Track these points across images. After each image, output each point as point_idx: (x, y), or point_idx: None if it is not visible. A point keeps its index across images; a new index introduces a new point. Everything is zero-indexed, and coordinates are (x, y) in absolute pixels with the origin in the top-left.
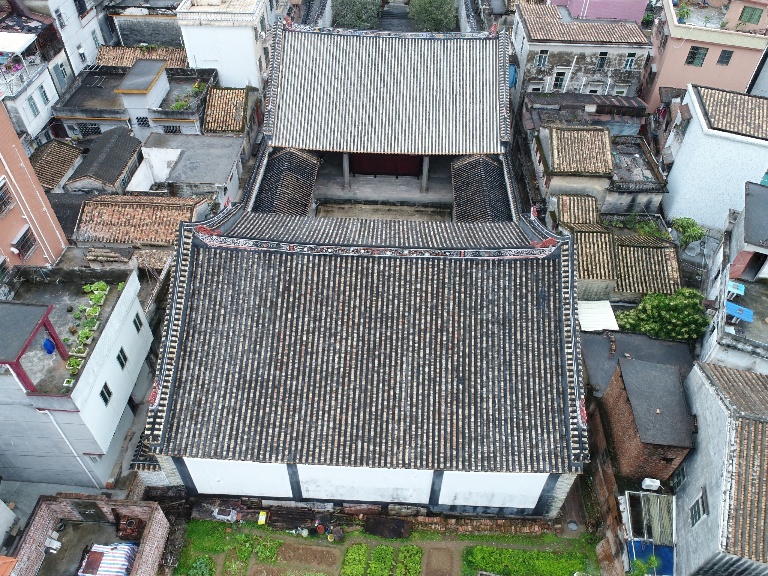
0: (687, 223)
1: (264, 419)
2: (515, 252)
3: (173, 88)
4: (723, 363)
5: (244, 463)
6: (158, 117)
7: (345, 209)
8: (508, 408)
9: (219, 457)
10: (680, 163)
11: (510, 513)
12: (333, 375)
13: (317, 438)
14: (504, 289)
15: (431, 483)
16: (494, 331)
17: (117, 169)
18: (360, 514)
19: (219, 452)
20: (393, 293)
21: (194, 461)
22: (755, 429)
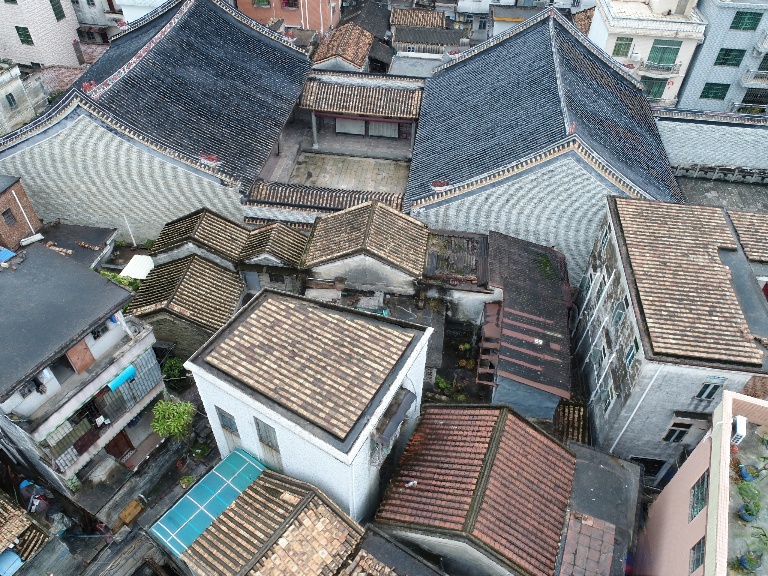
0: None
1: None
2: None
3: None
4: None
5: None
6: None
7: None
8: None
9: None
10: None
11: None
12: None
13: None
14: None
15: None
16: None
17: (414, 39)
18: None
19: None
20: None
21: None
22: None
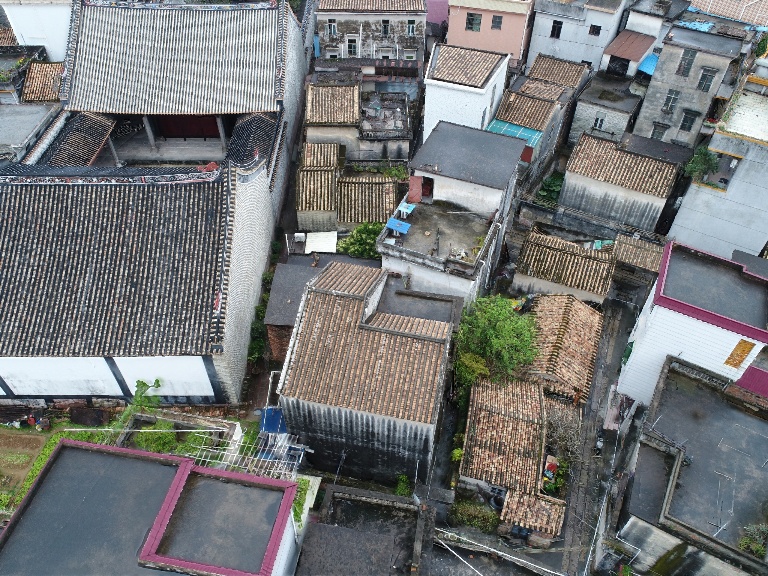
0: None
1: None
2: (187, 176)
3: (0, 64)
4: (390, 271)
5: None
6: None
7: None
8: (170, 305)
9: None
10: None
11: (198, 402)
12: (24, 284)
13: (3, 335)
14: (179, 208)
15: (112, 373)
16: (167, 243)
17: None
18: (68, 408)
19: None
20: (83, 215)
21: None
22: (322, 300)
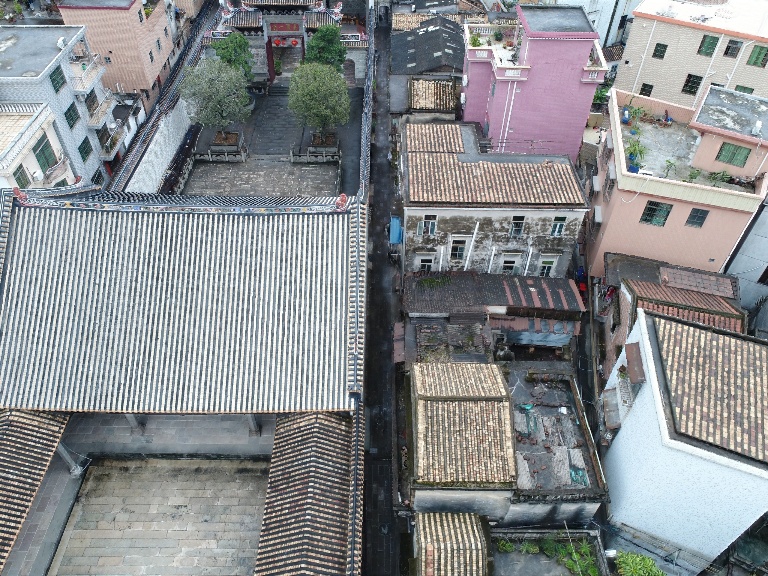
0: None
1: None
2: None
3: None
4: None
5: None
6: None
7: (129, 472)
8: None
9: None
10: (629, 444)
11: None
12: None
13: None
14: None
15: None
16: None
17: None
18: None
19: None
20: None
21: None
22: None
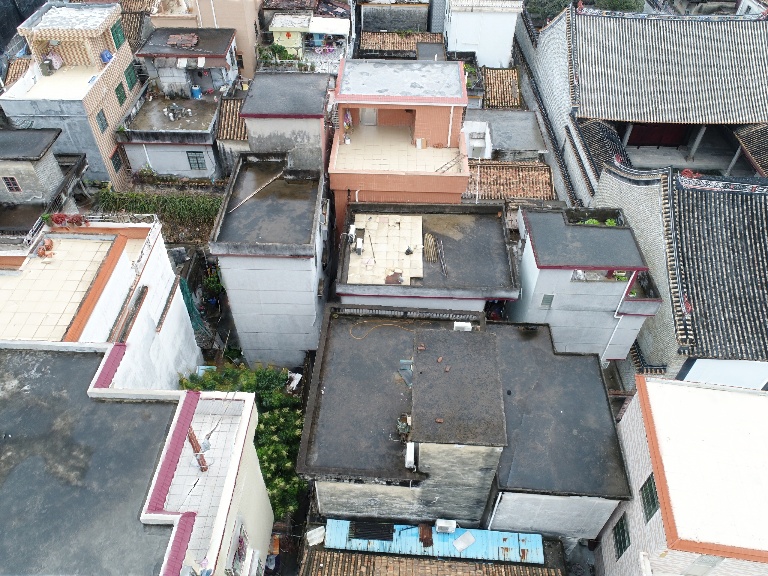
0: None
1: (762, 328)
2: None
3: None
4: None
5: (744, 365)
6: None
7: None
8: None
9: (737, 357)
10: None
11: None
12: None
13: None
14: None
15: None
16: None
17: None
18: None
19: (735, 354)
20: None
21: (702, 364)
22: None
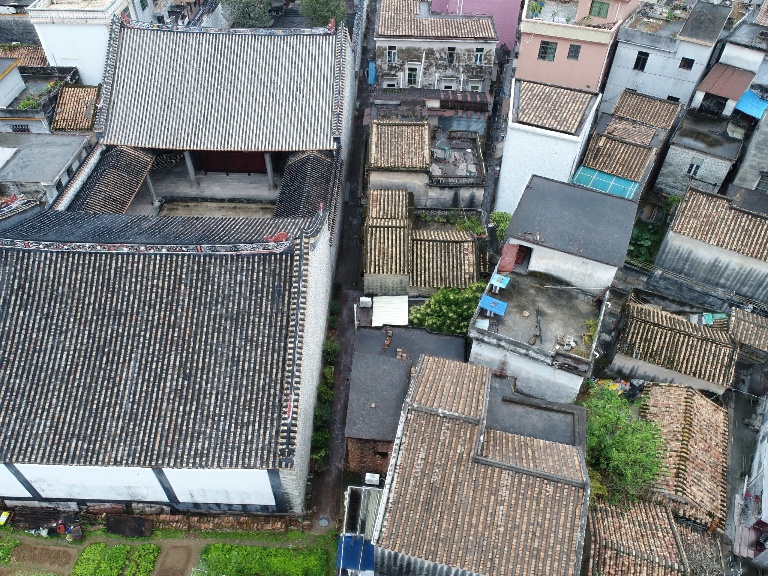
0: (501, 217)
1: None
2: (251, 247)
3: (29, 87)
4: (481, 357)
5: None
6: (3, 116)
7: (190, 207)
8: (229, 404)
9: None
10: (503, 157)
11: (256, 510)
12: (58, 373)
13: (32, 437)
14: (240, 284)
15: (158, 481)
16: (226, 327)
17: None
18: (103, 513)
19: None
20: (128, 289)
21: None
22: (426, 422)
